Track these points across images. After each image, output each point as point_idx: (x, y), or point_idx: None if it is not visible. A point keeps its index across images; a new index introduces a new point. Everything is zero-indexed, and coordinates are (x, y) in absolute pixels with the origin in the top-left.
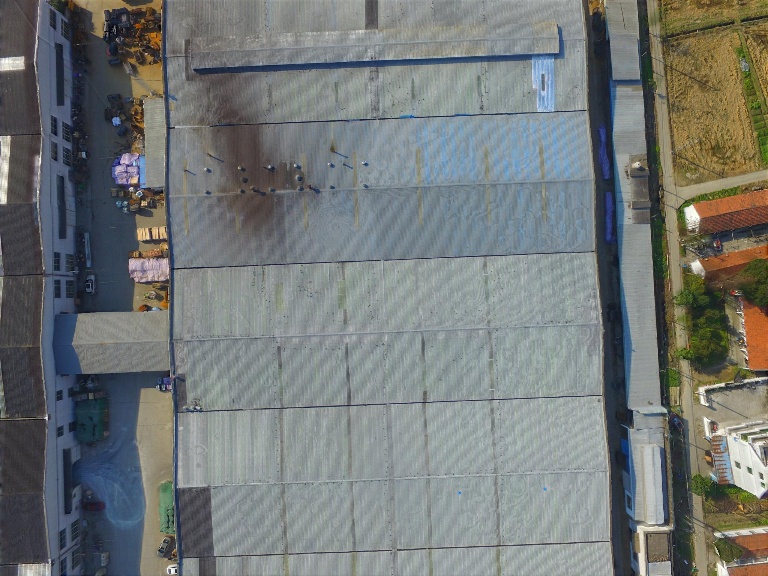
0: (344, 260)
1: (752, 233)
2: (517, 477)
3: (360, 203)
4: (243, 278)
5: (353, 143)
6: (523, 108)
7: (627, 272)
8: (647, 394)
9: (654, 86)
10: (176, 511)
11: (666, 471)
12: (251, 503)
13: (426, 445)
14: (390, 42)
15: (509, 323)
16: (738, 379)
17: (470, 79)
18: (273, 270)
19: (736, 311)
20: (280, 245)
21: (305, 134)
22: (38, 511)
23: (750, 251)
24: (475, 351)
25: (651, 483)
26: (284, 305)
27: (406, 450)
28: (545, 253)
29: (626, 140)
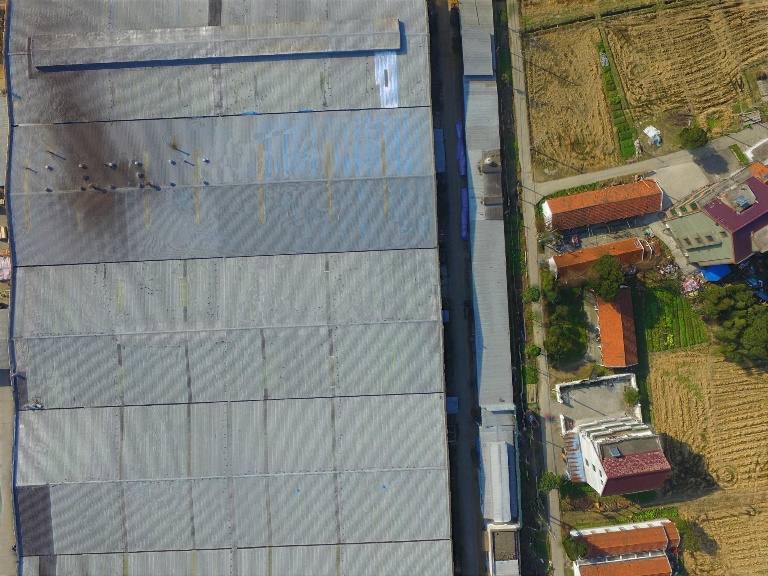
0: (186, 257)
1: (608, 229)
2: (356, 475)
3: (201, 200)
4: (85, 276)
5: (195, 140)
6: (366, 104)
7: (479, 269)
8: (499, 391)
9: (505, 81)
10: (15, 509)
11: (515, 469)
12: (90, 501)
13: (265, 443)
14: (230, 39)
15: (349, 320)
16: (593, 376)
17: (313, 75)
18: (115, 268)
19: (594, 308)
20: (122, 243)
21: (148, 131)
22: None
23: (604, 247)
24: (315, 348)
25: (497, 481)
26: (125, 303)
27: (245, 448)
28: (387, 250)
29: (479, 136)
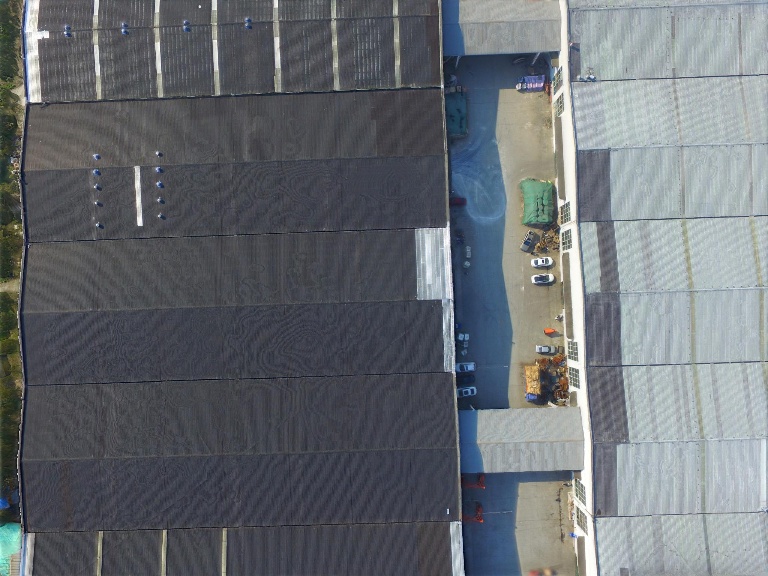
0: None
1: None
2: None
3: None
4: None
5: None
6: None
7: None
8: None
9: None
10: (577, 173)
11: None
12: (650, 166)
13: None
14: None
15: None
16: None
17: None
18: None
19: None
20: None
21: None
22: (438, 173)
23: None
24: None
25: None
26: None
27: None
28: None
29: None
